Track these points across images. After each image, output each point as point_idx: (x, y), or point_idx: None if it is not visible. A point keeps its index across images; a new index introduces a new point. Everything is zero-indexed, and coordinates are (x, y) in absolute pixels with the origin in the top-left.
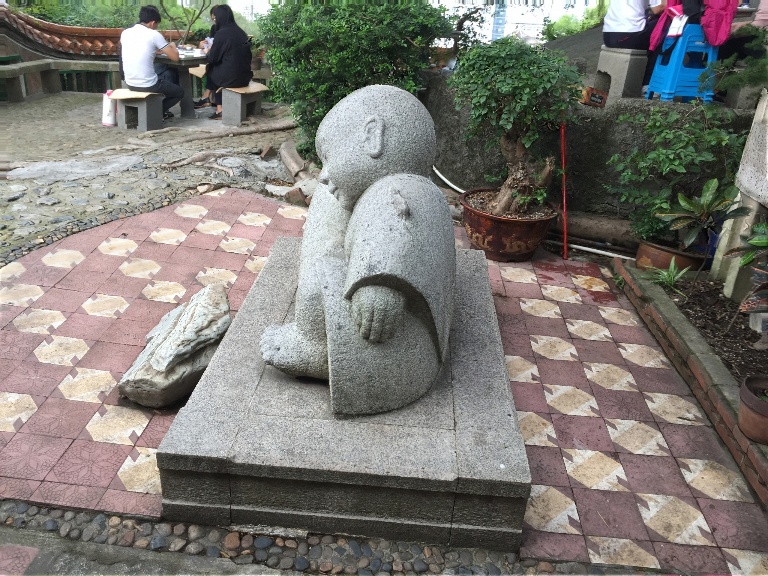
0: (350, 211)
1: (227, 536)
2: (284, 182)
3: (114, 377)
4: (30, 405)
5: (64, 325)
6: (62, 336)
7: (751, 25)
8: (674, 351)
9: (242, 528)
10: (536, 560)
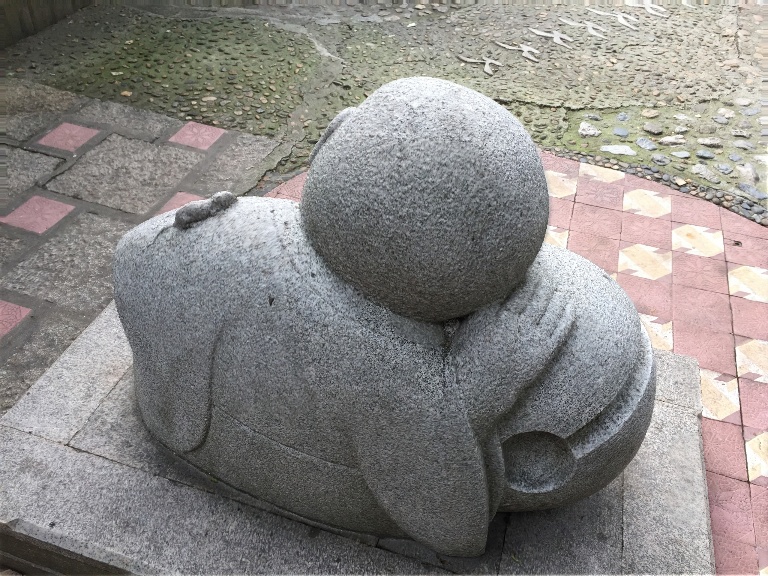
0: None
1: None
2: None
3: None
4: None
5: None
6: None
7: None
8: None
9: None
10: None
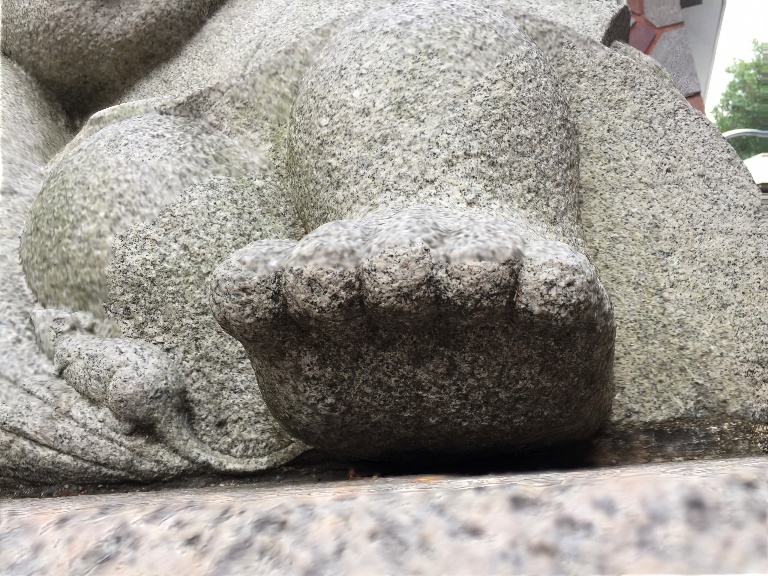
0: (179, 36)
1: None
2: None
3: None
4: None
5: None
6: None
7: None
8: None
9: None
10: None
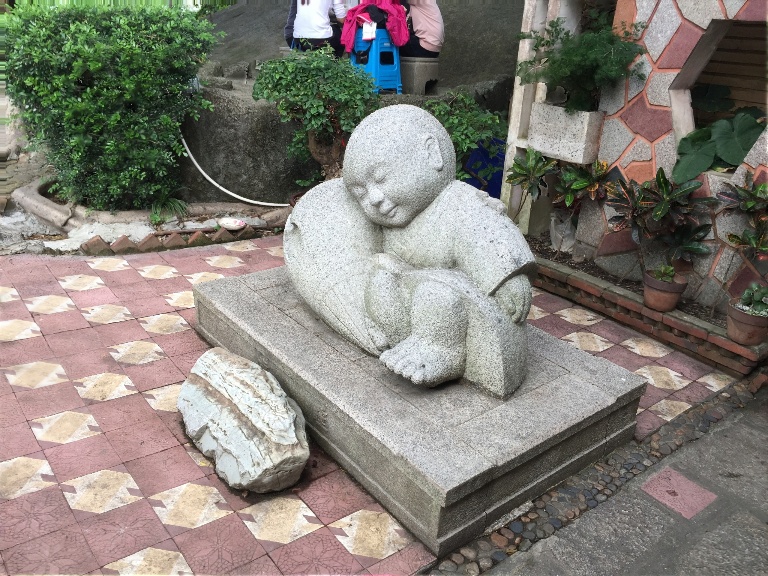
0: (404, 225)
1: (493, 539)
2: (47, 235)
3: (203, 485)
4: (168, 555)
5: (56, 467)
6: (76, 478)
7: (525, 32)
8: (541, 280)
9: (494, 527)
10: (648, 436)
